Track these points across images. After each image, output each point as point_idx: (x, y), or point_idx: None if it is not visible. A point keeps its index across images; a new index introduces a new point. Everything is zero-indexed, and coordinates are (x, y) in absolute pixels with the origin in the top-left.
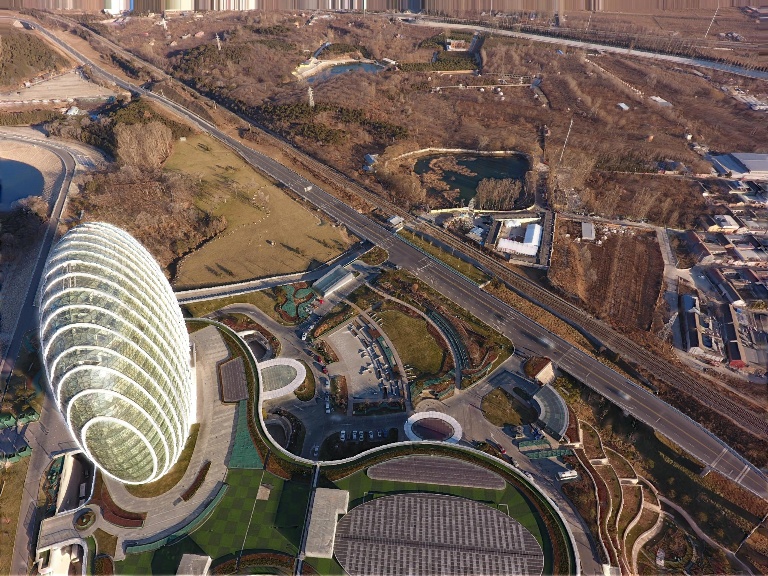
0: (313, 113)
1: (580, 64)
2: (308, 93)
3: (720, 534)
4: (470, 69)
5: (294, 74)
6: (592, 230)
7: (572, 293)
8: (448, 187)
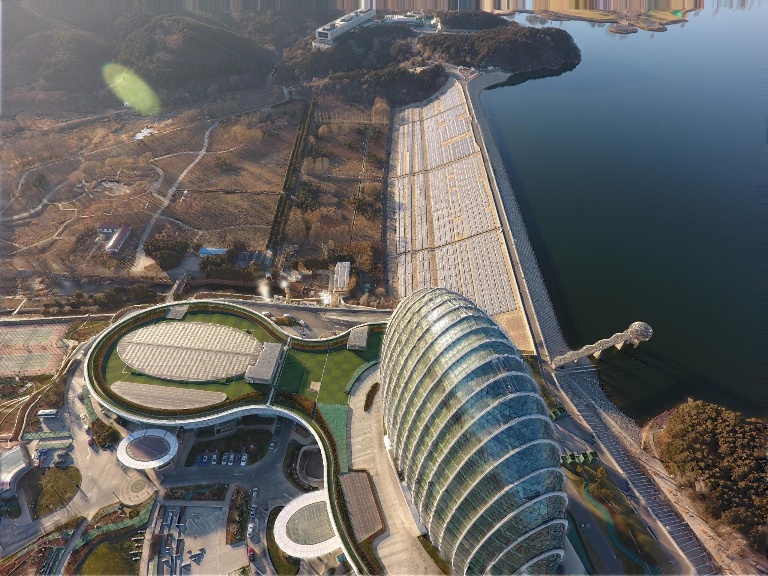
0: None
1: None
2: None
3: None
4: None
5: None
6: None
7: None
8: None
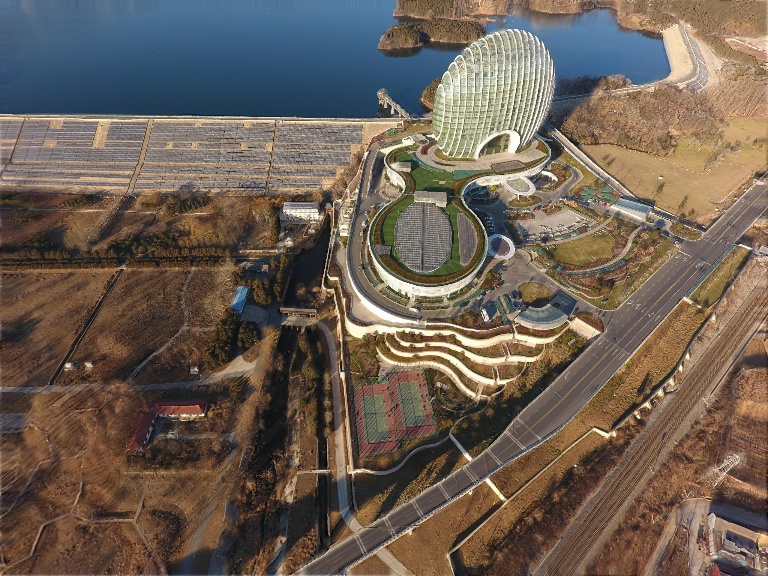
0: None
1: None
2: None
3: (463, 424)
4: None
5: None
6: None
7: (739, 390)
8: None
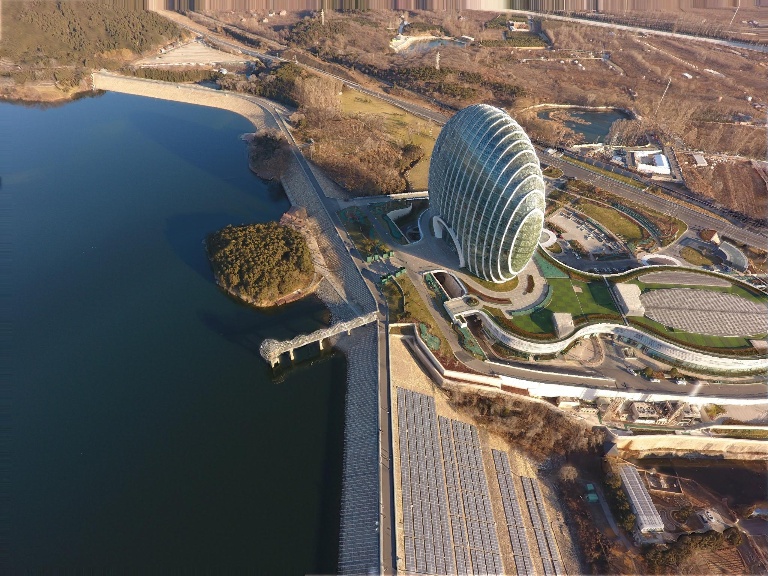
0: (442, 74)
1: (635, 43)
2: (436, 58)
3: None
4: (542, 46)
5: (392, 47)
6: (703, 159)
7: (708, 197)
8: (573, 132)
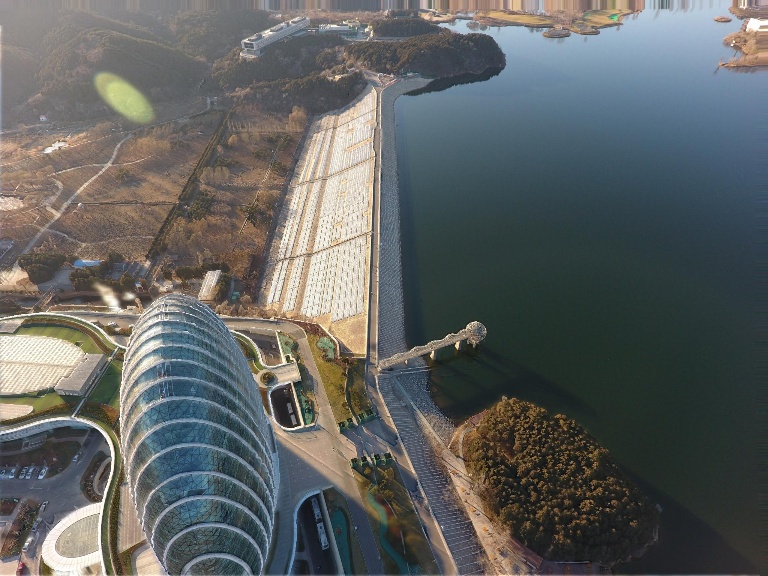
0: None
1: None
2: None
3: None
4: None
5: None
6: None
7: None
8: None
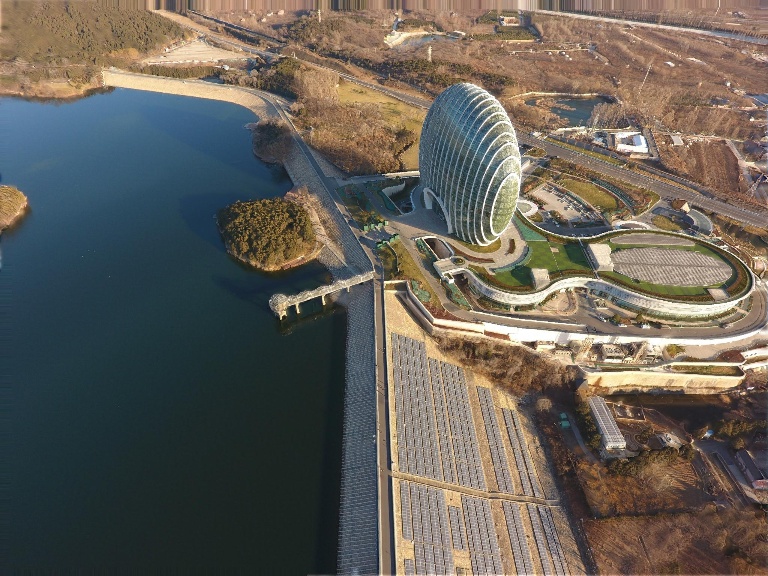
0: (434, 66)
1: (621, 35)
2: (428, 50)
3: None
4: (532, 39)
5: (386, 42)
6: (680, 139)
7: (682, 172)
8: (558, 117)
